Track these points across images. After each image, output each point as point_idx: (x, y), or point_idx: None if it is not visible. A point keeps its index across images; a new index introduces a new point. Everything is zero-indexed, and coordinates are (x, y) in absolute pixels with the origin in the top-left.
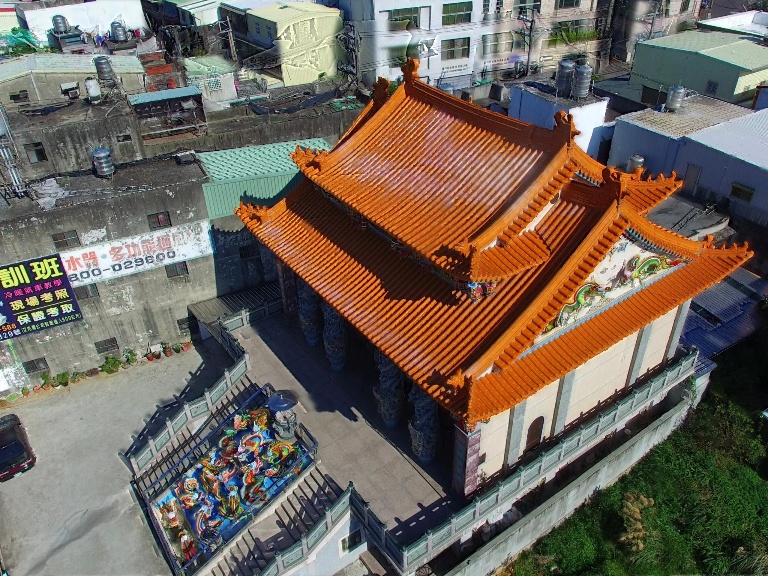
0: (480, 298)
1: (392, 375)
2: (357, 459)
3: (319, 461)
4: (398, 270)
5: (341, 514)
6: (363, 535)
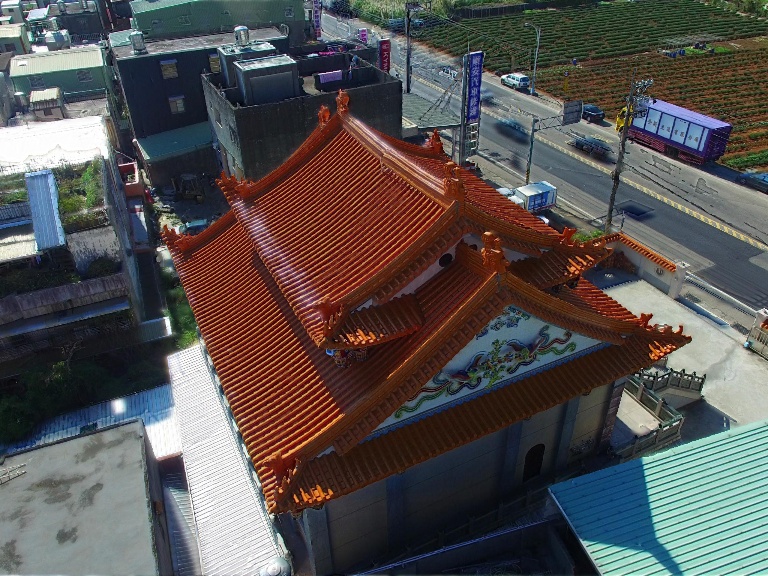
0: None
1: None
2: None
3: None
4: None
5: None
6: None
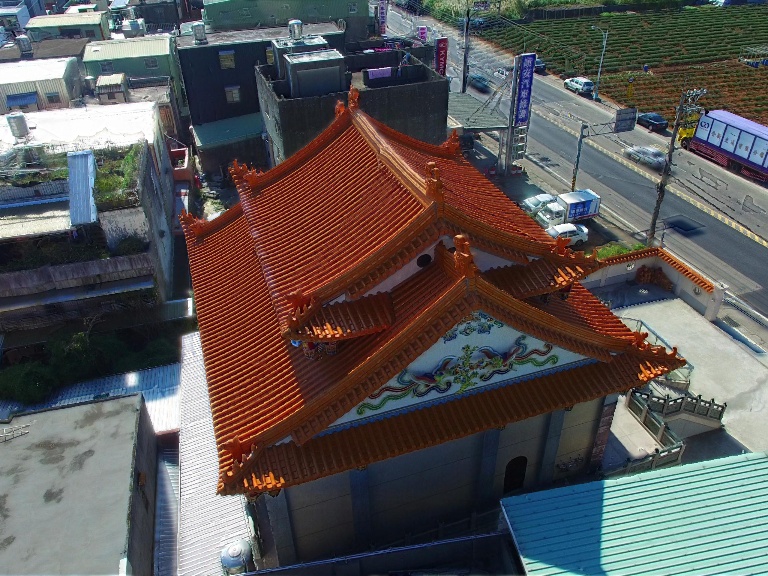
0: None
1: None
2: None
3: None
4: None
5: None
6: None
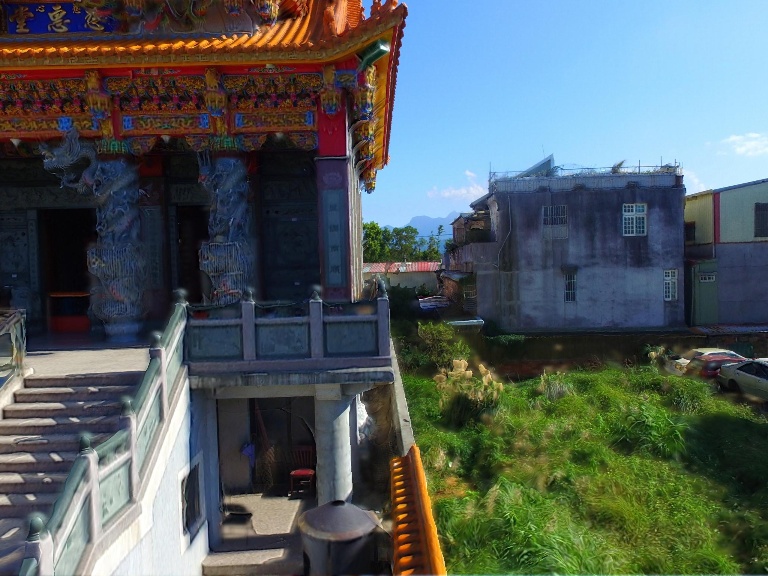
0: (259, 33)
1: (131, 201)
2: (114, 360)
3: (28, 370)
4: (94, 43)
5: (175, 383)
6: (201, 492)
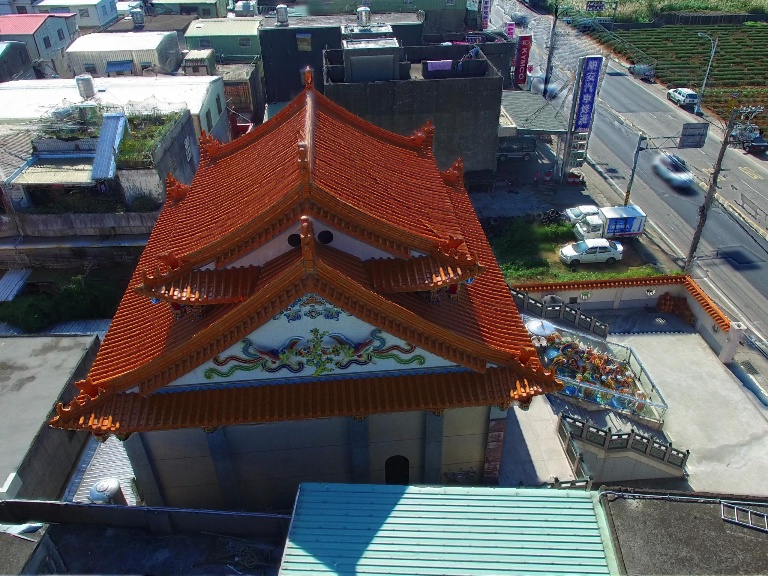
0: None
1: None
2: None
3: None
4: None
5: None
6: None
